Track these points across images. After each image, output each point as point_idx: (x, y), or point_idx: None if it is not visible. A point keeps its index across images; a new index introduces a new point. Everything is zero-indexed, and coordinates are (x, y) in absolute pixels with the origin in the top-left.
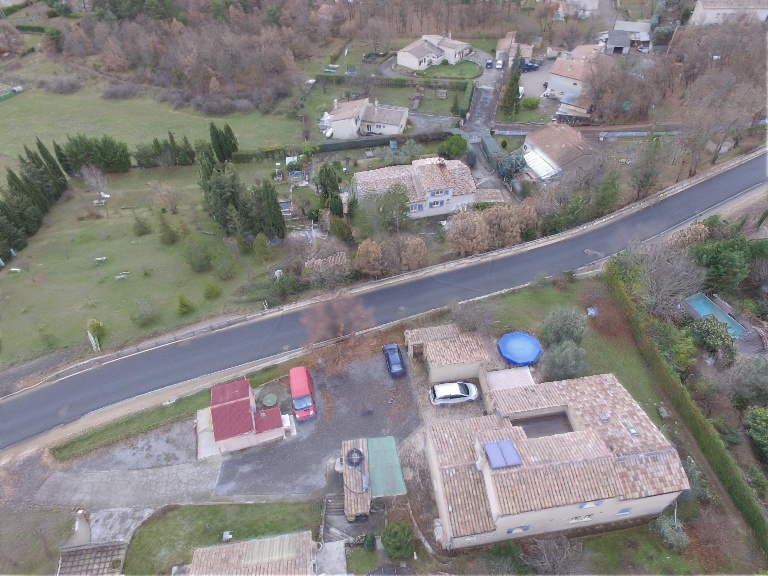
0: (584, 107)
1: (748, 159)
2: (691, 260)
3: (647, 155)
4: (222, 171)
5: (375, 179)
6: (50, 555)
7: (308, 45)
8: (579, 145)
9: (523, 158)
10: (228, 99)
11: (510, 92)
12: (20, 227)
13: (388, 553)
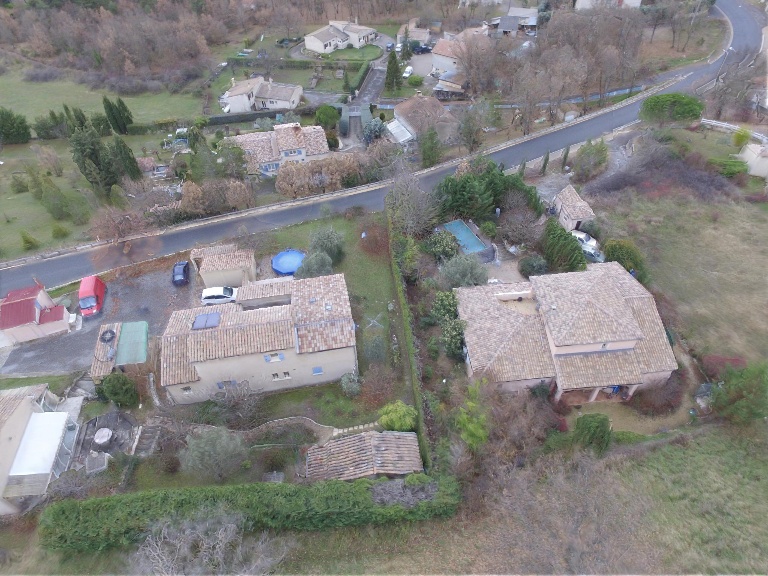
0: (459, 83)
1: (575, 123)
2: (441, 188)
3: (467, 115)
4: (81, 130)
5: (237, 141)
6: None
7: (223, 31)
8: None
9: (381, 125)
10: (139, 80)
11: (390, 69)
12: None
13: (113, 401)
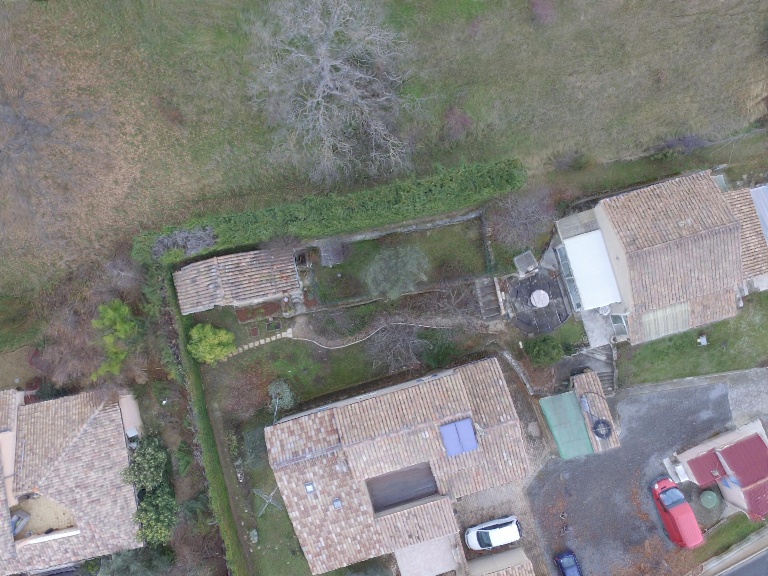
0: None
1: None
2: None
3: None
4: None
5: None
6: None
7: None
8: None
9: None
10: None
11: None
12: None
13: None
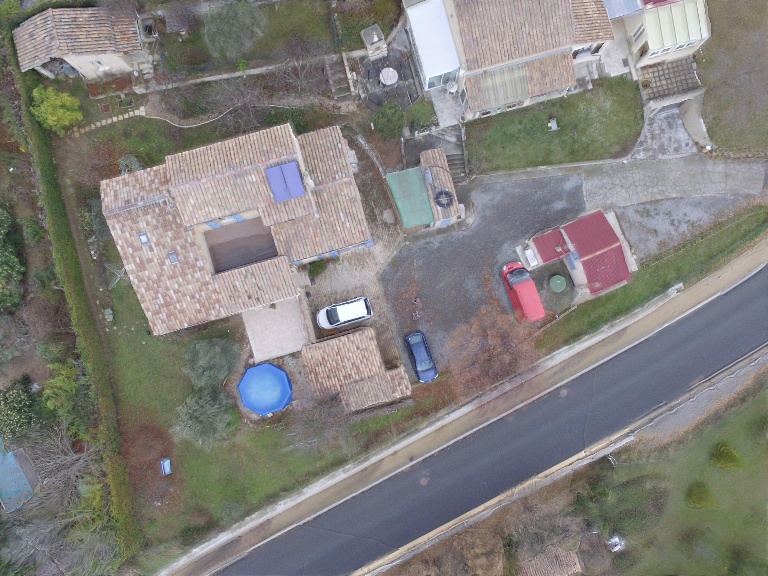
0: None
1: None
2: None
3: None
4: None
5: None
6: (712, 87)
7: None
8: None
9: None
10: None
11: None
12: None
13: None
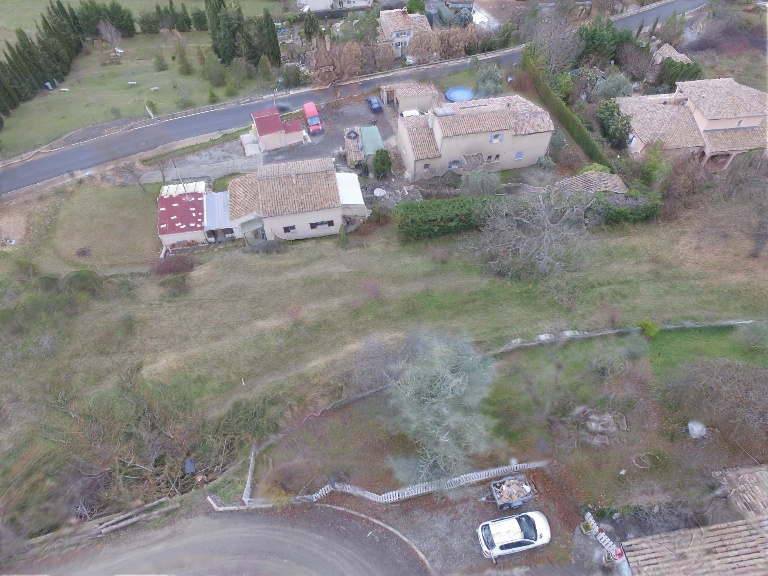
0: None
1: (644, 9)
2: (576, 37)
3: None
4: (229, 5)
5: None
6: None
7: None
8: (516, 6)
9: (470, 14)
10: None
11: None
12: (57, 64)
13: (377, 174)
